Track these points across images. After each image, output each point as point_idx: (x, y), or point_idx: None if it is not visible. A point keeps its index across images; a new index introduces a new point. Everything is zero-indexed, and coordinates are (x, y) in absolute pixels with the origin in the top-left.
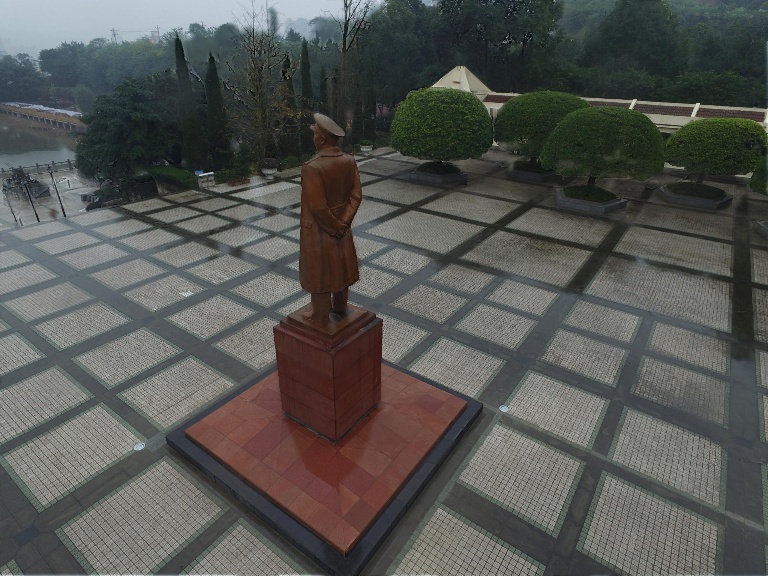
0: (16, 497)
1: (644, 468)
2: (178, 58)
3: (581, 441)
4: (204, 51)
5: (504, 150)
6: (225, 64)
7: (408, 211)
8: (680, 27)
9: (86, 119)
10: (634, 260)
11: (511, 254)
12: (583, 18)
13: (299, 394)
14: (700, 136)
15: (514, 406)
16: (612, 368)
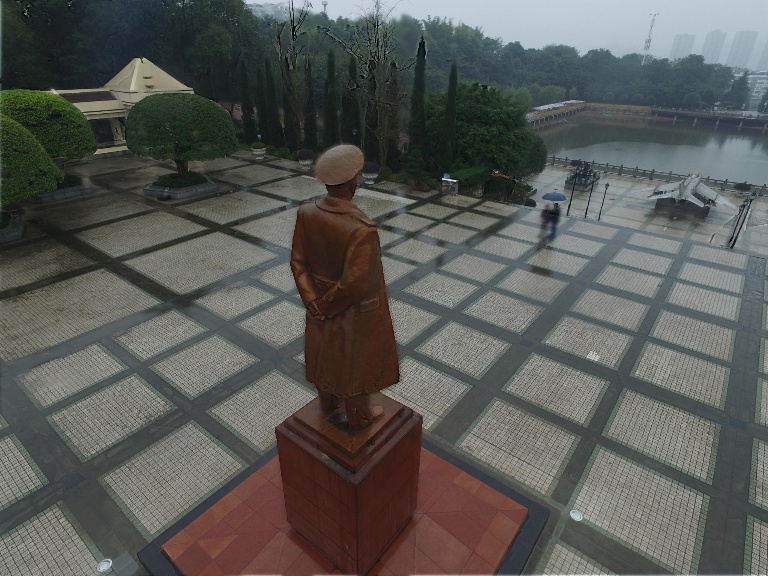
0: None
1: None
2: None
3: None
4: None
5: None
6: None
7: None
8: None
9: None
10: None
11: None
12: None
13: None
14: None
15: None
16: None
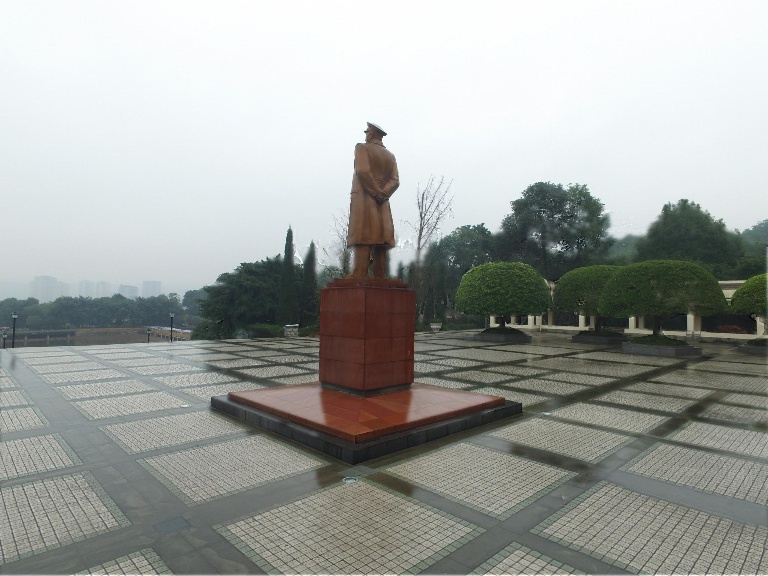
0: (75, 414)
1: (711, 444)
2: (288, 242)
3: (633, 429)
4: (308, 239)
5: (571, 333)
6: (322, 250)
7: (469, 348)
8: (726, 228)
9: (209, 289)
10: (709, 371)
11: (570, 365)
12: (630, 227)
13: (335, 350)
14: (762, 285)
15: (558, 413)
16: (676, 406)
